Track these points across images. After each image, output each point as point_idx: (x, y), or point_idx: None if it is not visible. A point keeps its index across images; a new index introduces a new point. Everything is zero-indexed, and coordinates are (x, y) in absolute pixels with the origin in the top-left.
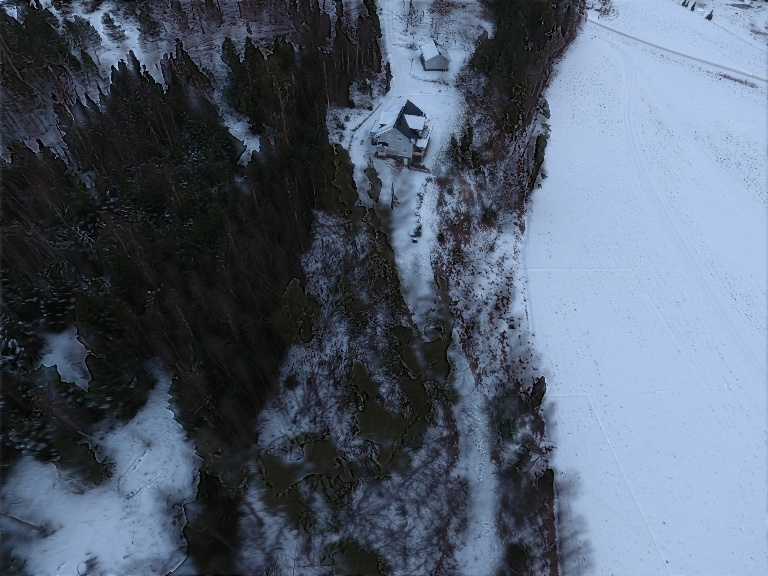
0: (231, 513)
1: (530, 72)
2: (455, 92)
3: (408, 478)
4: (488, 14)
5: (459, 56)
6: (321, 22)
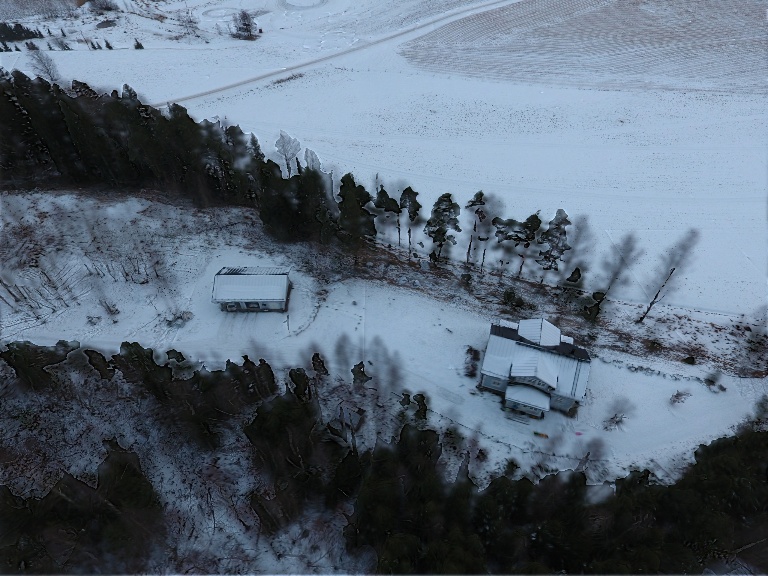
0: None
1: (330, 194)
2: (351, 286)
3: None
4: (87, 194)
5: (236, 259)
6: (142, 477)
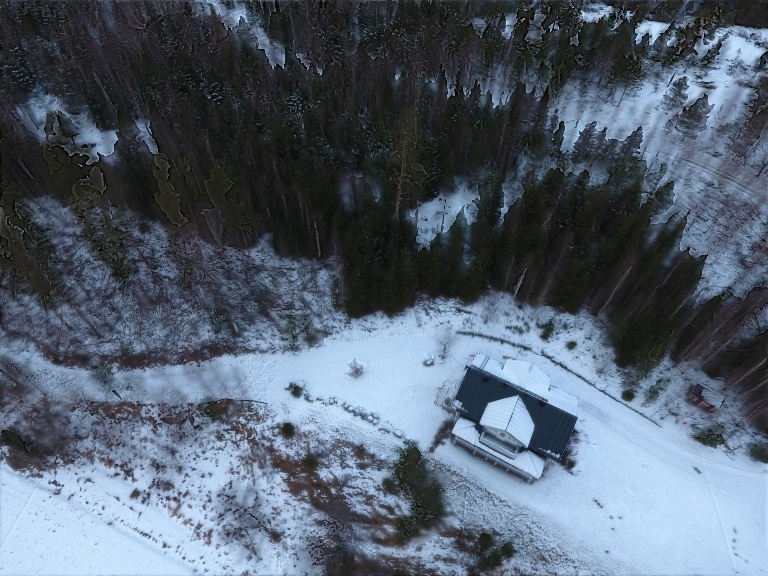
0: (66, 184)
1: None
2: None
3: (45, 304)
4: None
5: None
6: None
